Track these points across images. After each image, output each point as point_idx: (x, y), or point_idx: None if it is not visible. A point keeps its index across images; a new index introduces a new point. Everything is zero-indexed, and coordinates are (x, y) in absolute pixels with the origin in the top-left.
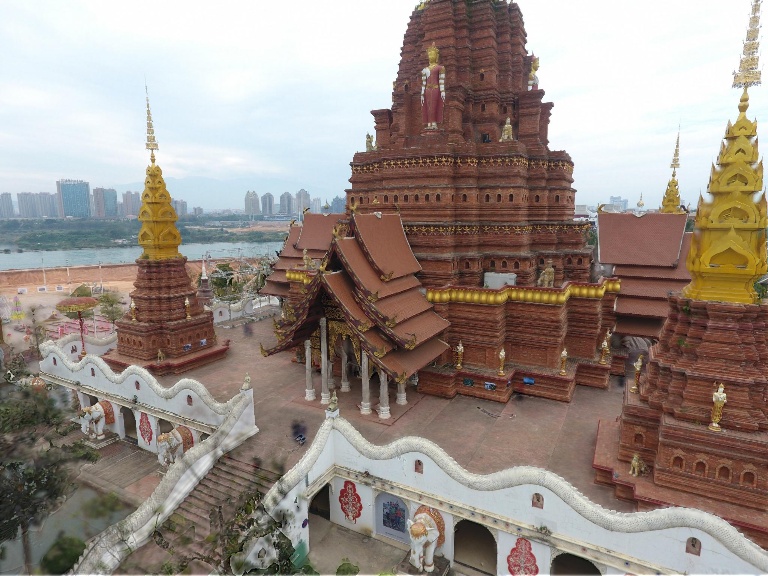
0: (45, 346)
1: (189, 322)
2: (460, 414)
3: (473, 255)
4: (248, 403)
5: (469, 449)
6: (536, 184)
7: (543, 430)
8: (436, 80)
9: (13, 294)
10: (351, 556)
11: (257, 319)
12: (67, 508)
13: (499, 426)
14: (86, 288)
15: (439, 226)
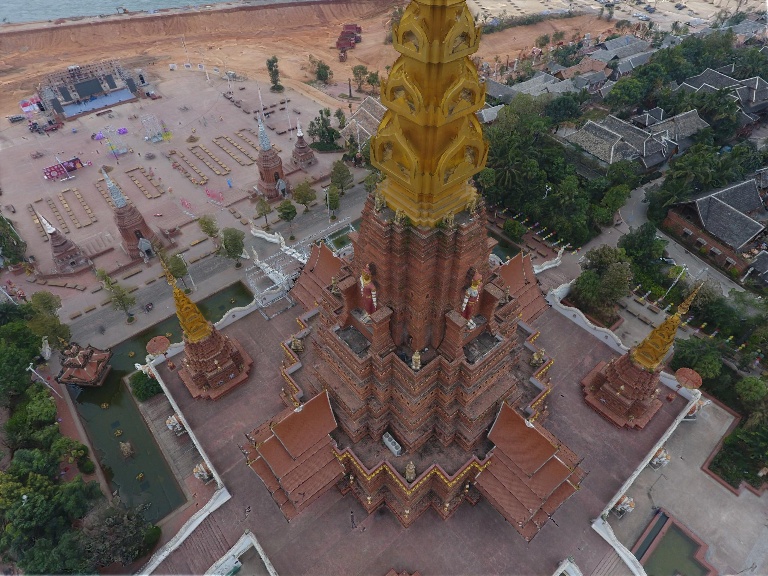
0: (148, 361)
1: (219, 372)
2: (337, 516)
3: (373, 428)
4: (222, 492)
5: (318, 556)
6: (443, 384)
7: (368, 553)
8: (369, 292)
9: (167, 70)
10: (257, 575)
11: (290, 306)
12: (162, 483)
13: (348, 539)
14: (178, 259)
15: (349, 409)
